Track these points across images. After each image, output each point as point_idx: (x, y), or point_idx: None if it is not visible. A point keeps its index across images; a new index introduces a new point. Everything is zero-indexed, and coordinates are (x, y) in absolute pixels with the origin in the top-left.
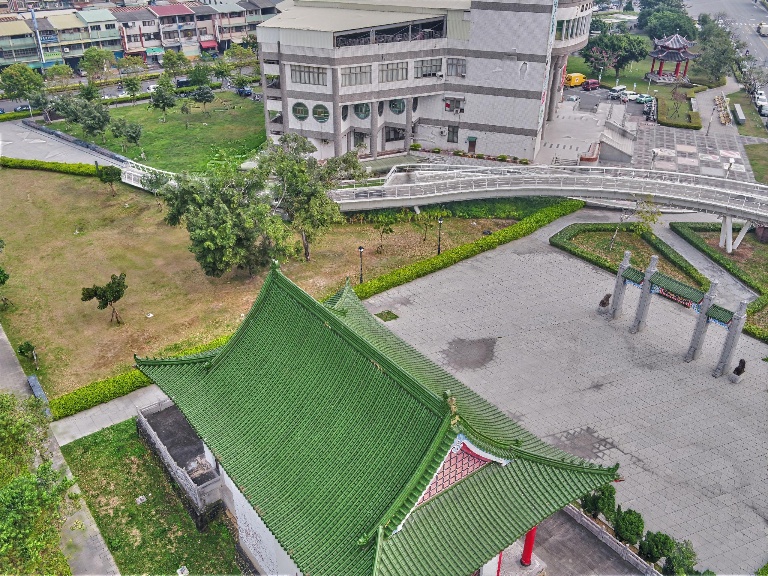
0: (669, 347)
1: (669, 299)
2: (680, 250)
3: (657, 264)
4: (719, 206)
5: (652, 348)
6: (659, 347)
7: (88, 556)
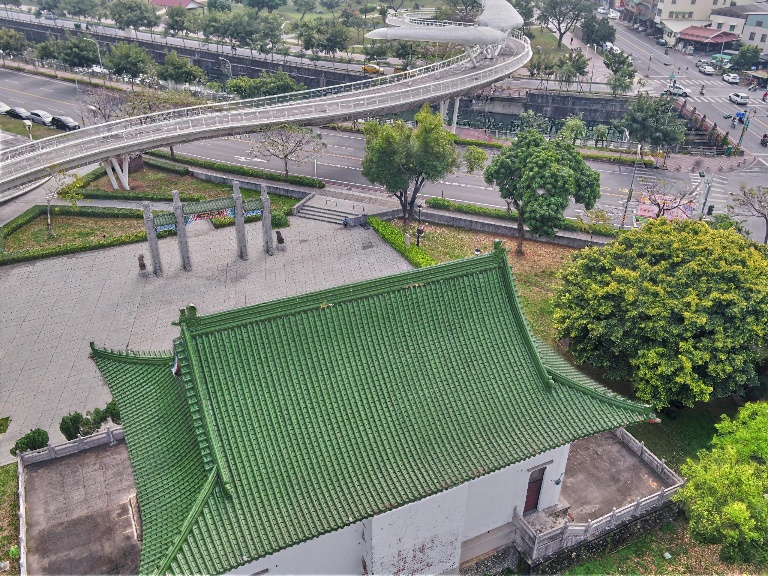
0: (223, 261)
1: (159, 238)
2: (99, 206)
3: (105, 224)
4: (106, 151)
5: (218, 268)
6: (219, 265)
7: None
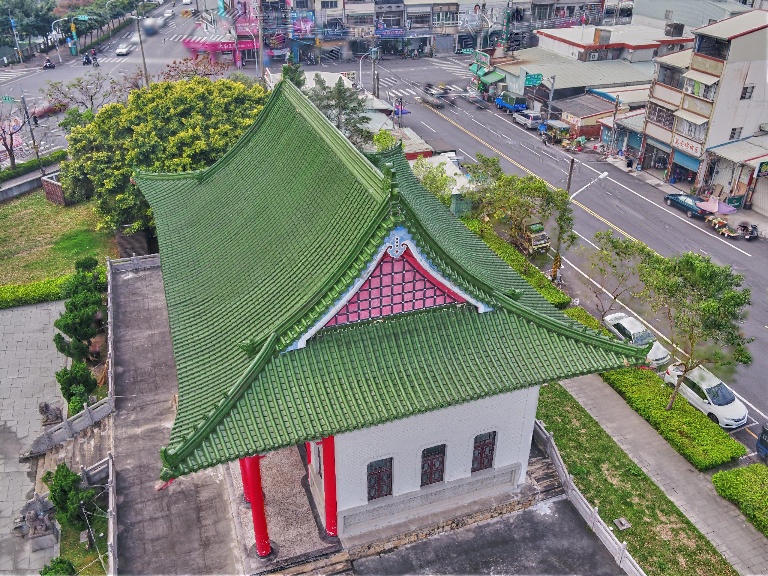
0: None
1: None
2: None
3: None
4: None
5: None
6: None
7: (664, 466)
